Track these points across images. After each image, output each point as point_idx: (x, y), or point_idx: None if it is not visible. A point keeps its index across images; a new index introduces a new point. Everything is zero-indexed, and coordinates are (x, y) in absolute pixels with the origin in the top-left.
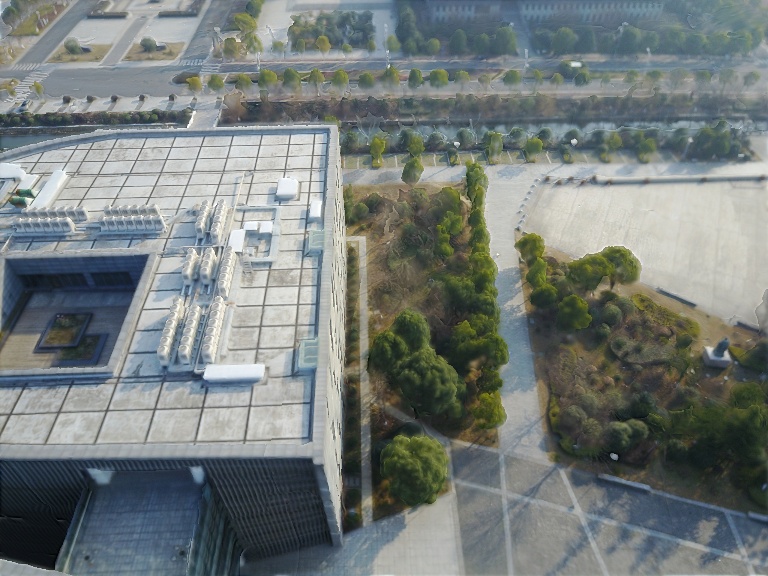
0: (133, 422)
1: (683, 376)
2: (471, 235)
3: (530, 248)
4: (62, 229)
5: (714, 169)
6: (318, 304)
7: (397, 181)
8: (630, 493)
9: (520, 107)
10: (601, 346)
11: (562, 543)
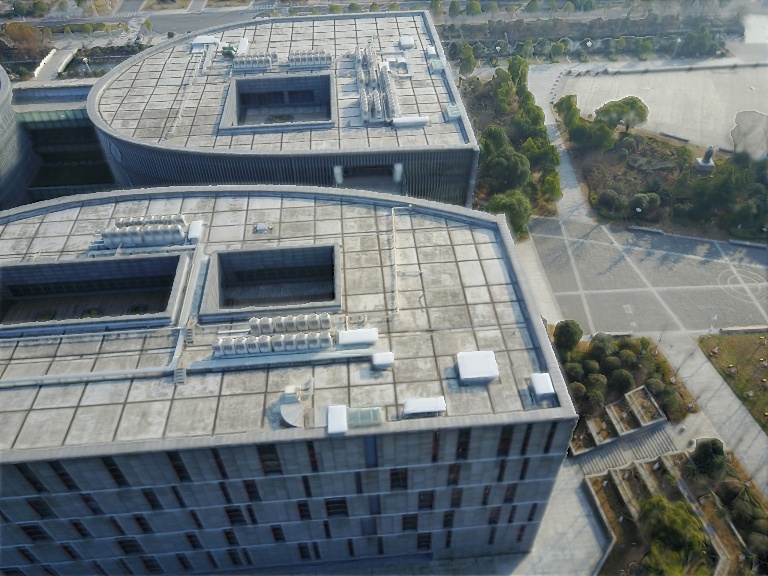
0: (358, 142)
1: (682, 170)
2: (520, 101)
3: (566, 104)
4: (264, 65)
5: (698, 63)
6: (450, 93)
7: None
8: (650, 235)
9: (541, 28)
10: (622, 163)
11: (608, 259)
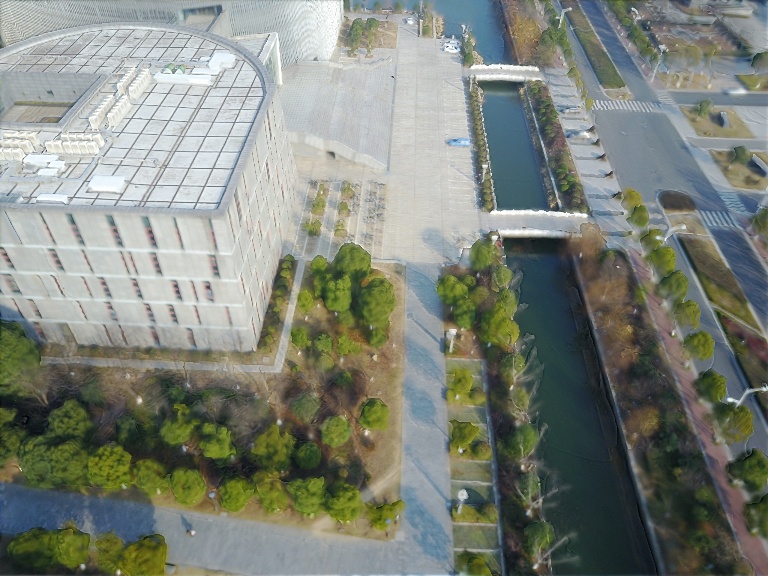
0: None
1: None
2: None
3: None
4: None
5: None
6: None
7: (407, 419)
8: None
9: None
10: None
11: None
